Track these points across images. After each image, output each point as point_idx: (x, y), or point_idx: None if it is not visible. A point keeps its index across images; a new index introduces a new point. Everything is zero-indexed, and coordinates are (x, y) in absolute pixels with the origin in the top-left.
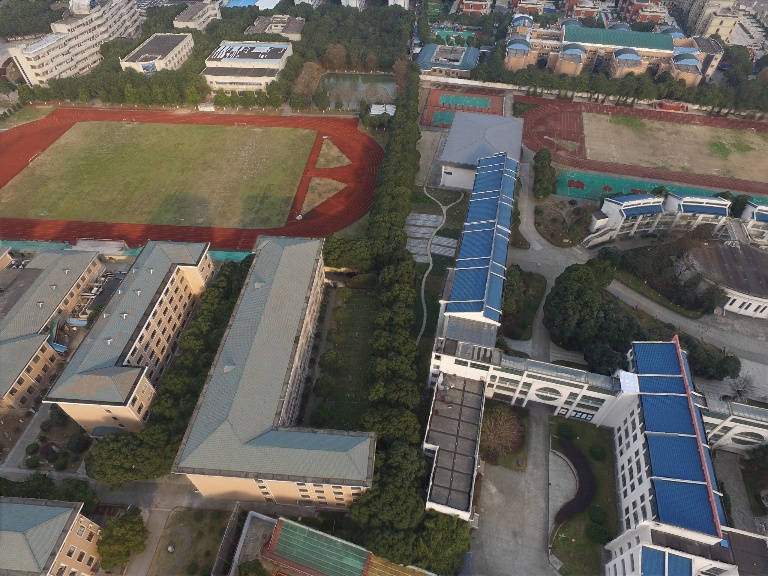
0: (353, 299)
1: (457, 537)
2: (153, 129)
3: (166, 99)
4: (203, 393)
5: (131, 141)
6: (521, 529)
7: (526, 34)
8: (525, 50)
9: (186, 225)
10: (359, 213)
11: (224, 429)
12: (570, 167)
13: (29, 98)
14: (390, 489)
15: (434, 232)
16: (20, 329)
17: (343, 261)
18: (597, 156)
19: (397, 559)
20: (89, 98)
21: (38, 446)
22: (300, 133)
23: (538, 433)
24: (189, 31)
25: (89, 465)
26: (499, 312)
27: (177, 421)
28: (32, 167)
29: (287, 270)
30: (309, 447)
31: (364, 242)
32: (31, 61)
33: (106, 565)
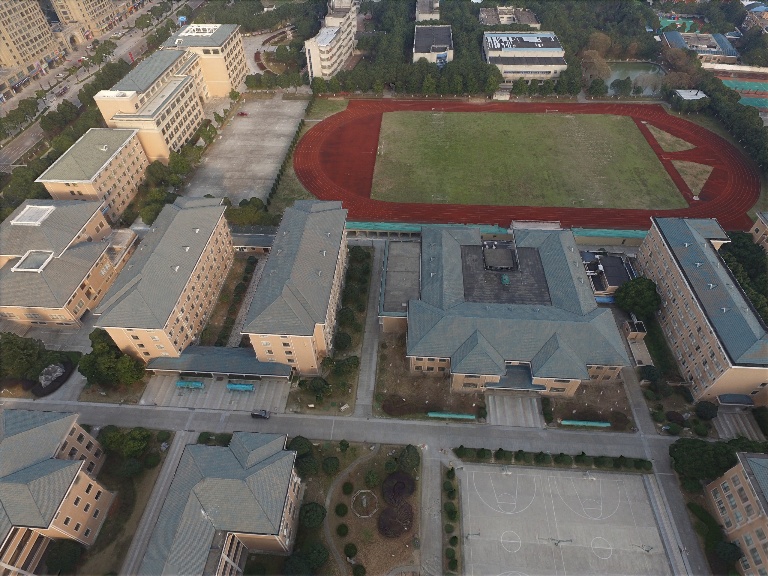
0: None
1: None
2: (465, 118)
3: (463, 88)
4: None
5: (455, 129)
6: None
7: None
8: None
9: (591, 207)
10: (752, 193)
11: None
12: None
13: (323, 90)
14: None
15: None
16: (587, 303)
17: None
18: None
19: None
20: (382, 89)
21: None
22: (615, 119)
23: None
24: (440, 23)
25: None
26: None
27: None
28: (383, 155)
29: None
30: None
31: None
32: (325, 54)
33: None
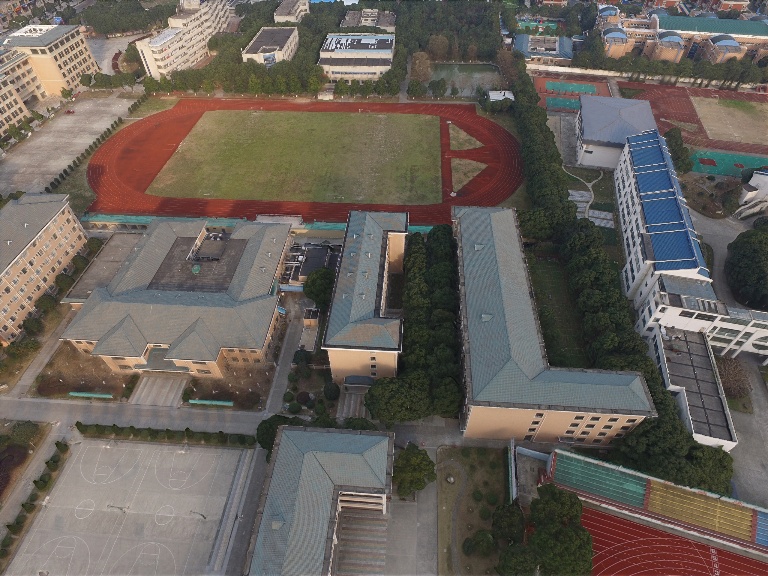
0: (537, 265)
1: (728, 464)
2: (281, 116)
3: (287, 88)
4: (467, 340)
5: (265, 128)
6: (767, 462)
7: (617, 23)
8: (622, 38)
9: (348, 202)
10: (509, 190)
11: (510, 367)
12: (696, 146)
13: (155, 89)
14: (668, 420)
15: (587, 206)
16: (254, 291)
17: (524, 230)
18: (718, 136)
19: (687, 481)
20: (212, 89)
21: (292, 394)
22: (423, 118)
23: (753, 381)
24: (291, 25)
25: (372, 404)
26: (707, 270)
27: (436, 367)
28: (181, 152)
29: (500, 234)
30: (592, 382)
31: (542, 212)
32: (156, 54)
33: (405, 491)
